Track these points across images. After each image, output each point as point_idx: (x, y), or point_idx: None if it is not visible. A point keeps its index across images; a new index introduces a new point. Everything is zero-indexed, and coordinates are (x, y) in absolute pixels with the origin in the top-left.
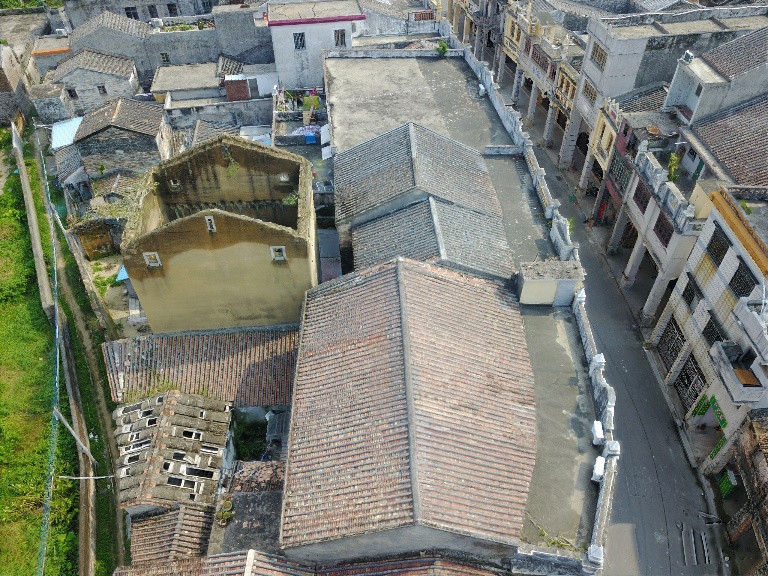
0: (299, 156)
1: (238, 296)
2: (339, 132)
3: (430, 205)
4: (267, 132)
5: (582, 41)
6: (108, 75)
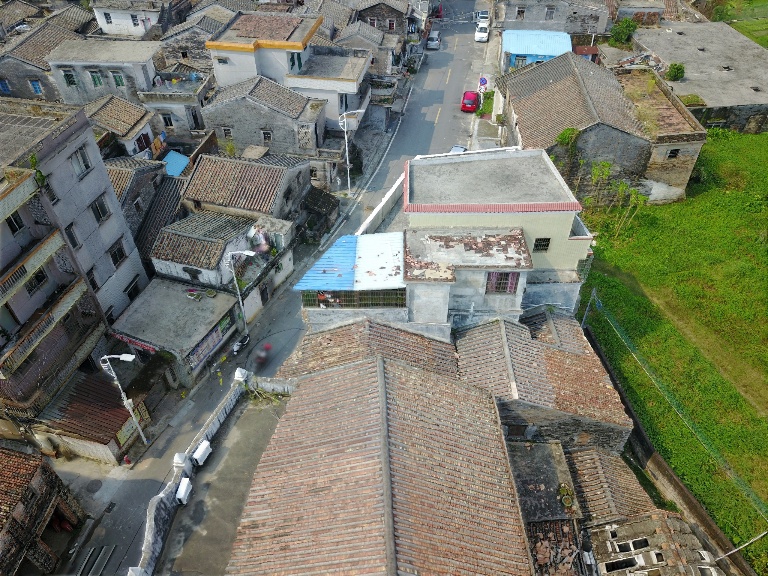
0: None
1: None
2: None
3: None
4: None
5: None
6: None
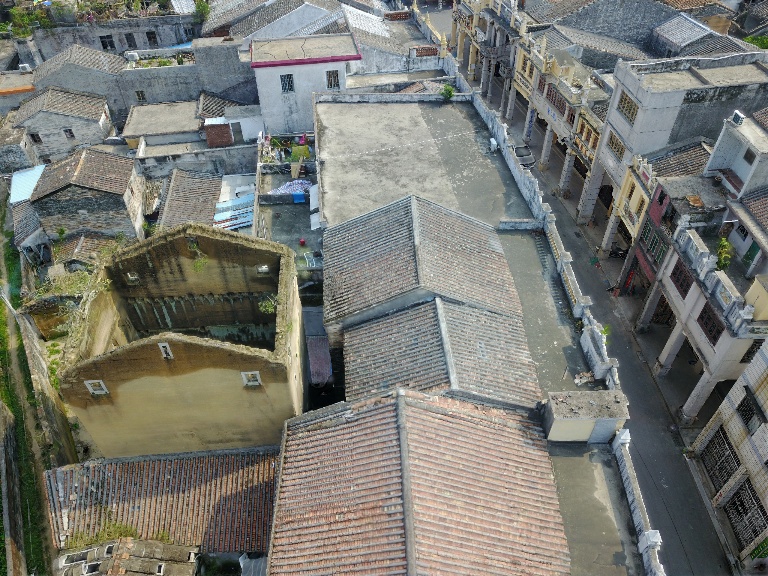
0: (280, 245)
1: (205, 421)
2: (330, 198)
3: (437, 309)
4: (252, 182)
5: (604, 82)
6: (75, 118)
